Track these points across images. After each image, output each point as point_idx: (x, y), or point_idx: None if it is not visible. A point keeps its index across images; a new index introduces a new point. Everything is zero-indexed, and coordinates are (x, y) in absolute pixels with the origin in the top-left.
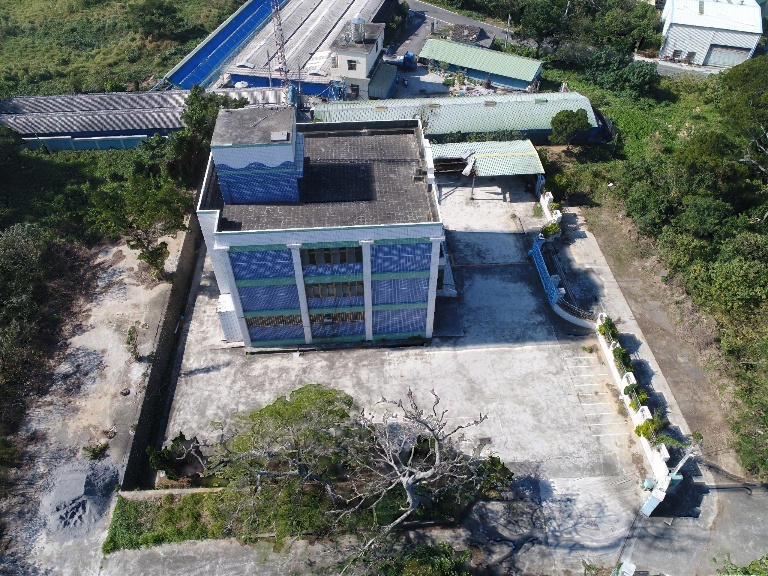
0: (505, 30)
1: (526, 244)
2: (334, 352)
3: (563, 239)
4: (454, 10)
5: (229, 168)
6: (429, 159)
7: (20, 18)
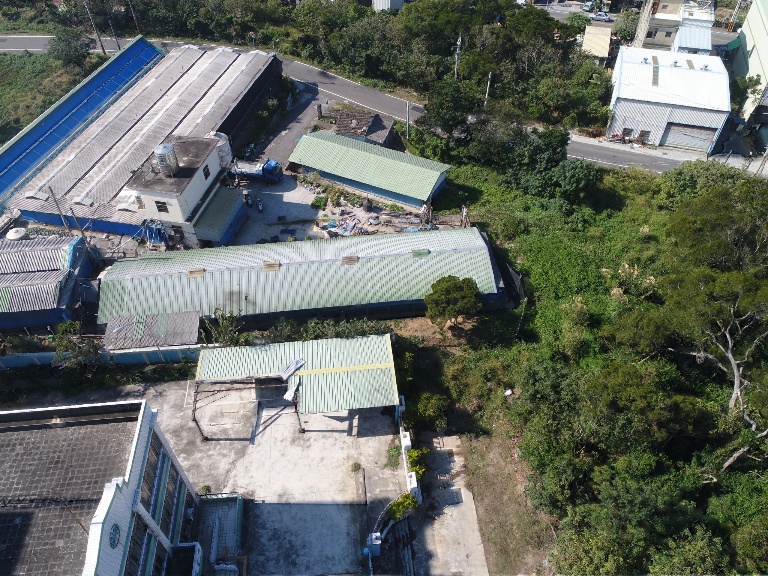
0: (416, 105)
1: (364, 529)
2: None
3: (426, 508)
4: (356, 79)
5: None
6: (91, 552)
7: None
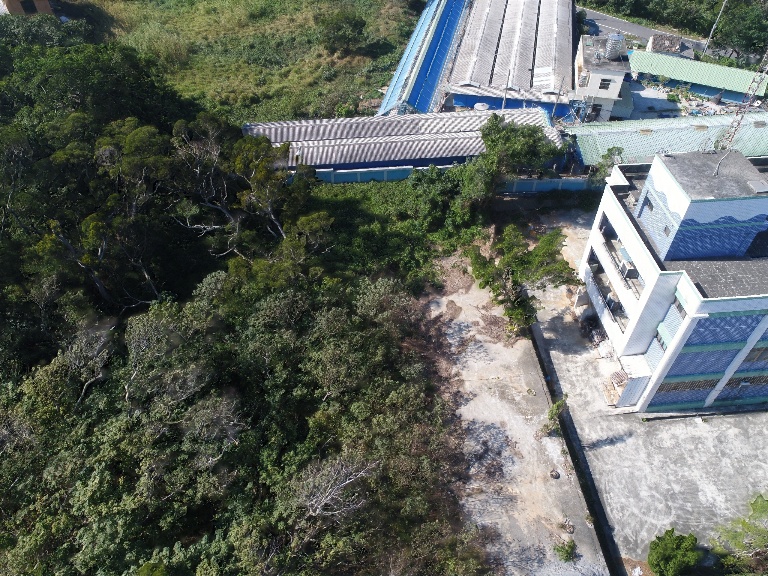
0: None
1: None
2: (739, 416)
3: None
4: (622, 17)
5: (694, 223)
6: None
7: (191, 34)
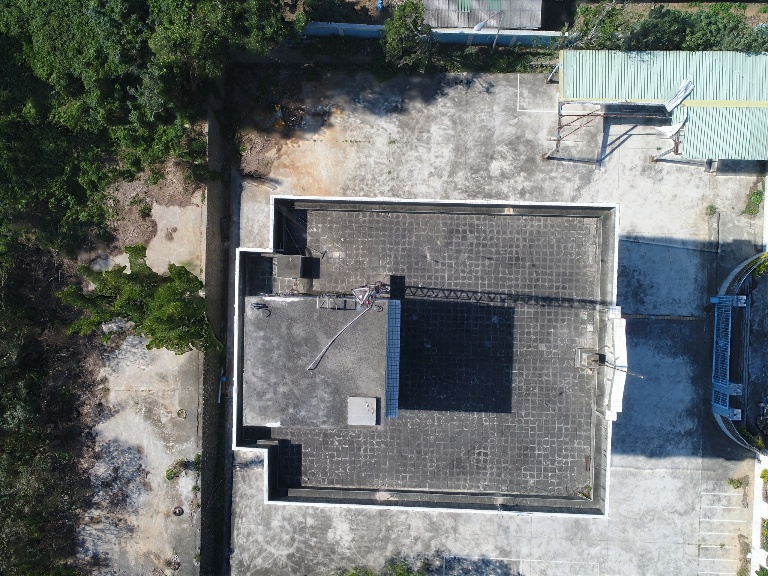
0: None
1: (713, 277)
2: None
3: None
4: None
5: None
6: (617, 391)
7: None
